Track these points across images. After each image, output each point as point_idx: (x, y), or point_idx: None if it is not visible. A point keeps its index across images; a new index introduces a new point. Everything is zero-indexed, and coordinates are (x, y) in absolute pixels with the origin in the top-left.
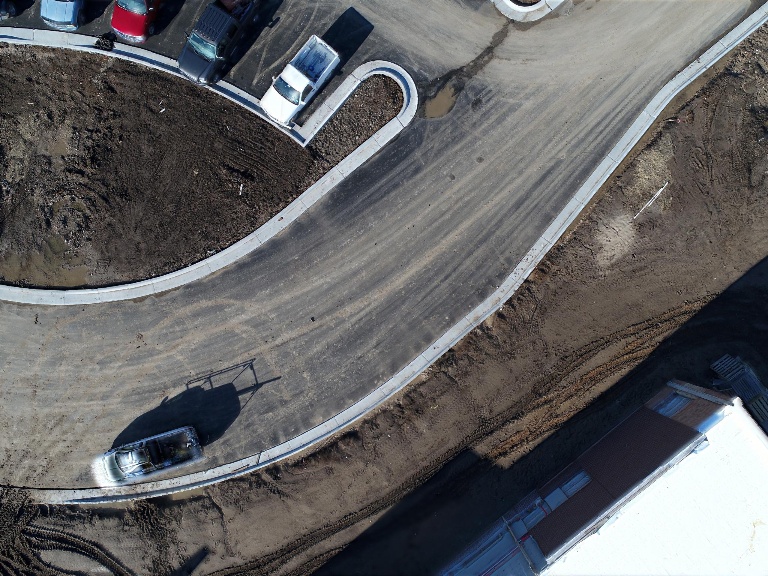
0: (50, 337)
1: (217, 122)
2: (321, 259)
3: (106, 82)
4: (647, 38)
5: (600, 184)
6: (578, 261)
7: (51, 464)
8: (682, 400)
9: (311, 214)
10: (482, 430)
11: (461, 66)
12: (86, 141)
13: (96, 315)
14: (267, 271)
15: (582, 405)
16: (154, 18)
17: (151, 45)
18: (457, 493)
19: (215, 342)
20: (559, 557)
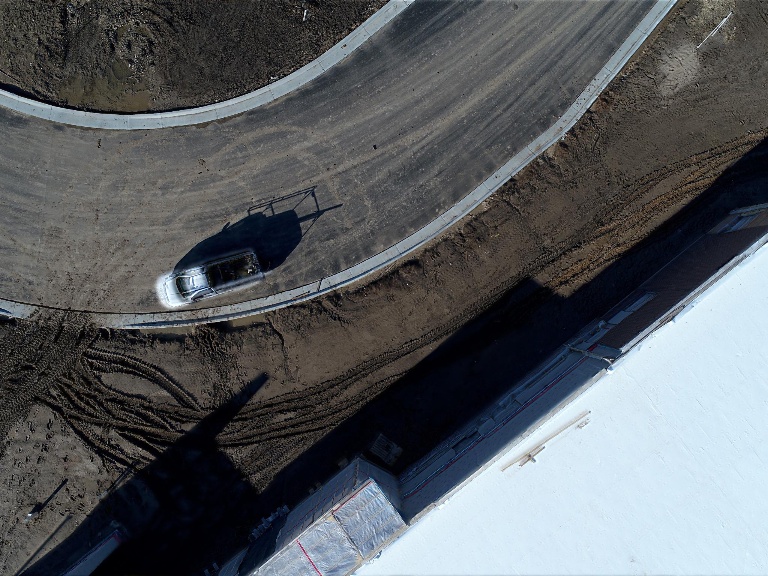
0: (113, 162)
1: None
2: (383, 87)
3: None
4: None
5: (663, 14)
6: (641, 90)
7: (112, 288)
8: (748, 219)
9: (374, 42)
10: (543, 258)
11: None
12: None
13: (159, 140)
14: (329, 98)
15: (644, 234)
16: None
17: None
18: (518, 321)
19: (277, 169)
20: (634, 345)
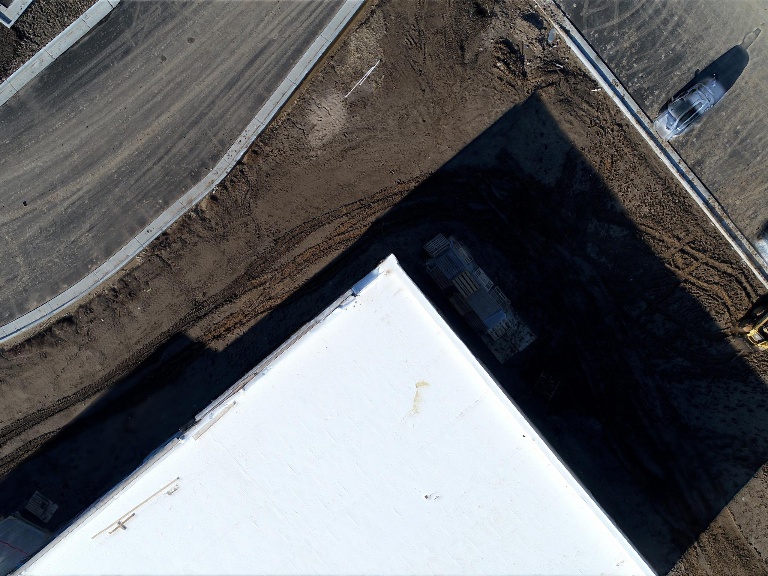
0: None
1: None
2: (32, 143)
3: None
4: None
5: (312, 63)
6: (290, 141)
7: None
8: None
9: (21, 97)
10: (195, 313)
11: None
12: None
13: None
14: None
15: (295, 287)
16: None
17: None
18: (171, 376)
19: None
20: (205, 414)
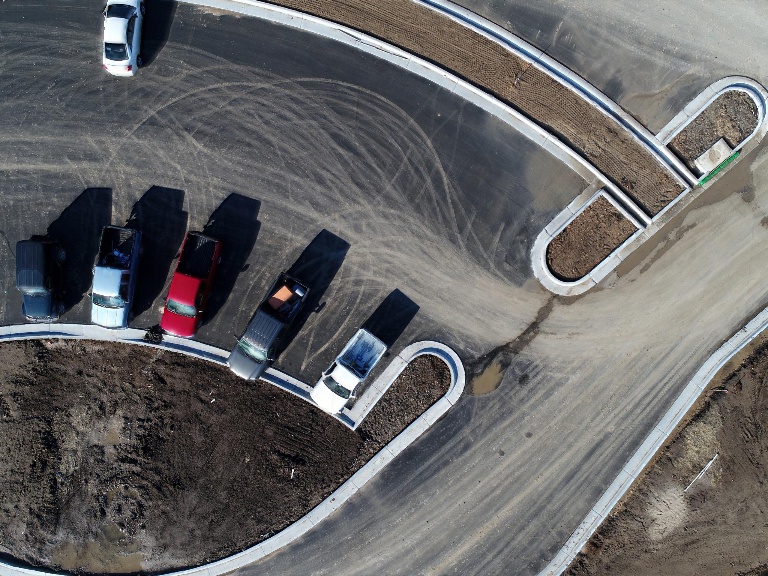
0: None
1: (267, 410)
2: (373, 538)
3: (156, 373)
4: (692, 308)
5: (649, 457)
6: (630, 534)
7: None
8: None
9: (362, 494)
10: None
11: (507, 342)
12: (138, 430)
13: None
14: (320, 552)
15: None
16: (202, 314)
17: (199, 336)
18: None
19: None
20: None
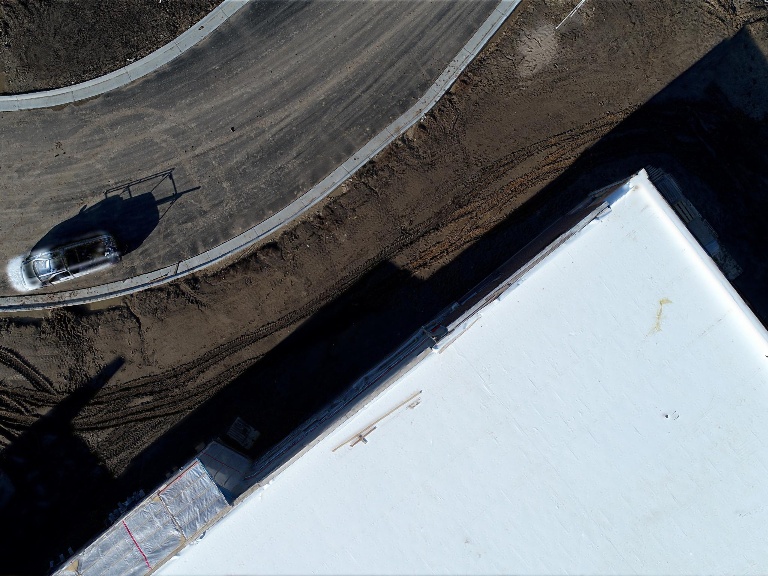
0: None
1: None
2: (241, 69)
3: None
4: None
5: None
6: (500, 72)
7: None
8: None
9: (232, 24)
10: (402, 240)
11: None
12: None
13: (15, 123)
14: (187, 80)
15: (502, 216)
16: None
17: None
18: (376, 304)
19: (134, 151)
20: (459, 323)
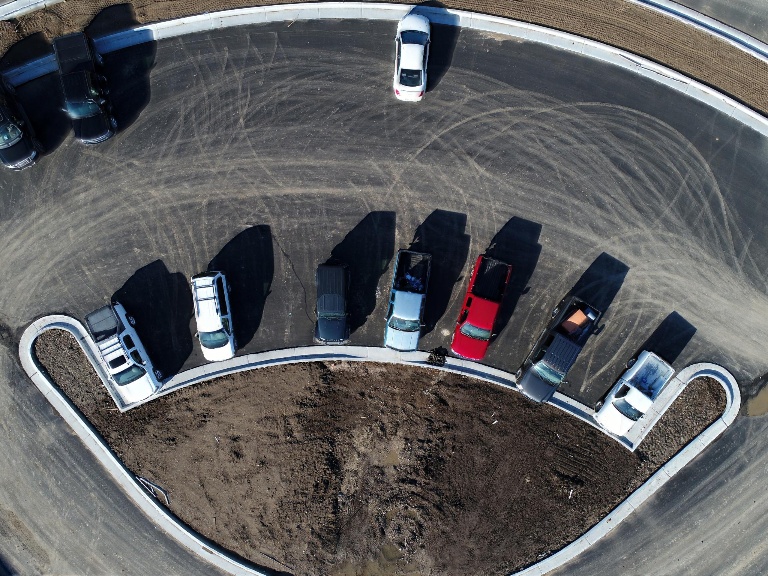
0: None
1: (548, 431)
2: (649, 558)
3: (437, 394)
4: None
5: None
6: None
7: None
8: None
9: (638, 514)
10: None
11: None
12: (417, 451)
13: None
14: (596, 571)
15: None
16: None
17: None
18: None
19: None
20: None
